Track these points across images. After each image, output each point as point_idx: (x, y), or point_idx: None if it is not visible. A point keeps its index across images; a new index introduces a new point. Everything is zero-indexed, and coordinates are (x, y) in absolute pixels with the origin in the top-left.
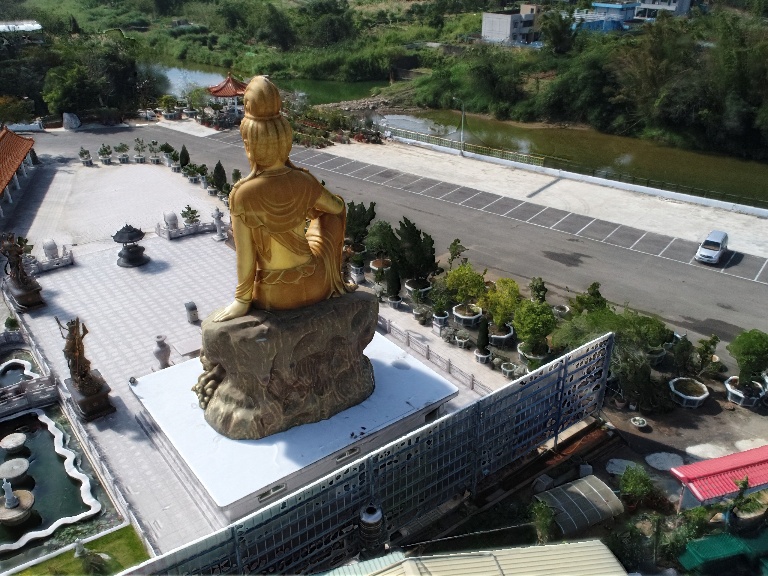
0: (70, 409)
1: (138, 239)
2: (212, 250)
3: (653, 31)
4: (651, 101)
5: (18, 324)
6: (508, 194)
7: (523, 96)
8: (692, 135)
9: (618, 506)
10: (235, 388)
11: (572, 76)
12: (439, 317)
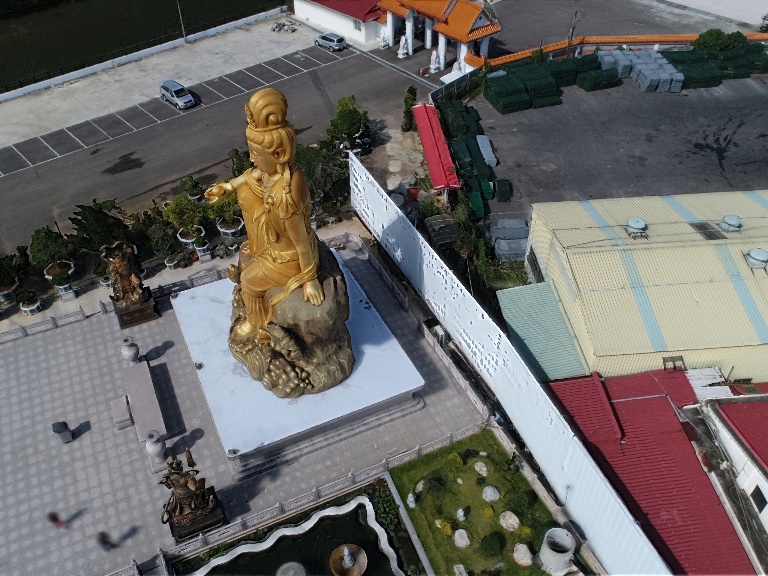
0: None
1: None
2: None
3: None
4: None
5: None
6: None
7: None
8: None
9: (453, 217)
10: (325, 348)
11: None
12: (206, 246)
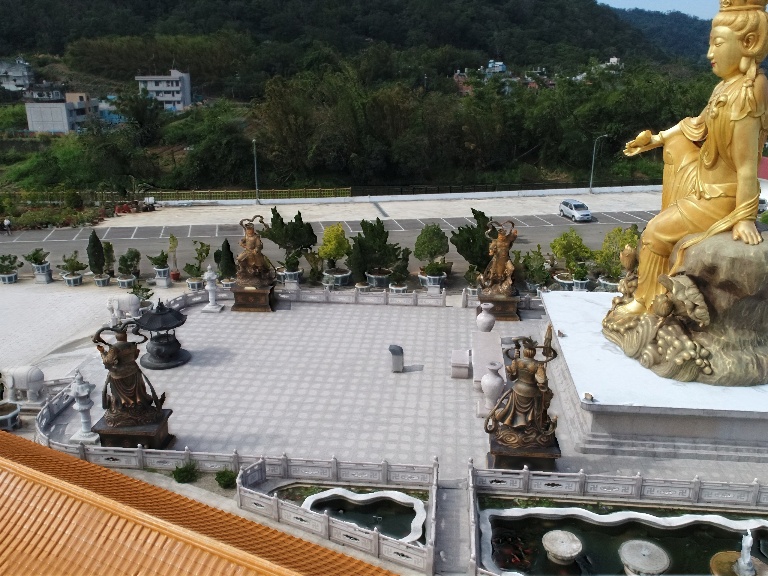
0: (547, 474)
1: (185, 318)
2: (235, 320)
3: (276, 94)
4: (303, 154)
5: (200, 470)
6: (368, 218)
7: (161, 171)
8: (339, 179)
9: None
10: (740, 330)
11: (213, 143)
12: (586, 281)
